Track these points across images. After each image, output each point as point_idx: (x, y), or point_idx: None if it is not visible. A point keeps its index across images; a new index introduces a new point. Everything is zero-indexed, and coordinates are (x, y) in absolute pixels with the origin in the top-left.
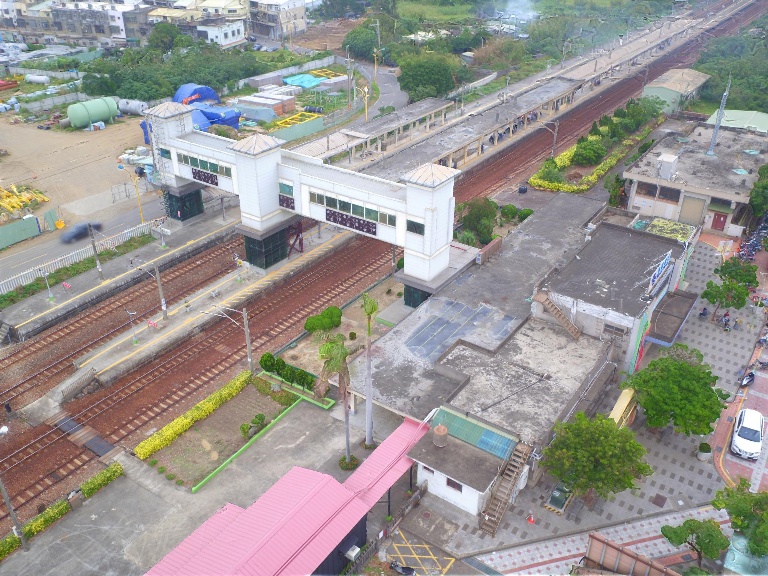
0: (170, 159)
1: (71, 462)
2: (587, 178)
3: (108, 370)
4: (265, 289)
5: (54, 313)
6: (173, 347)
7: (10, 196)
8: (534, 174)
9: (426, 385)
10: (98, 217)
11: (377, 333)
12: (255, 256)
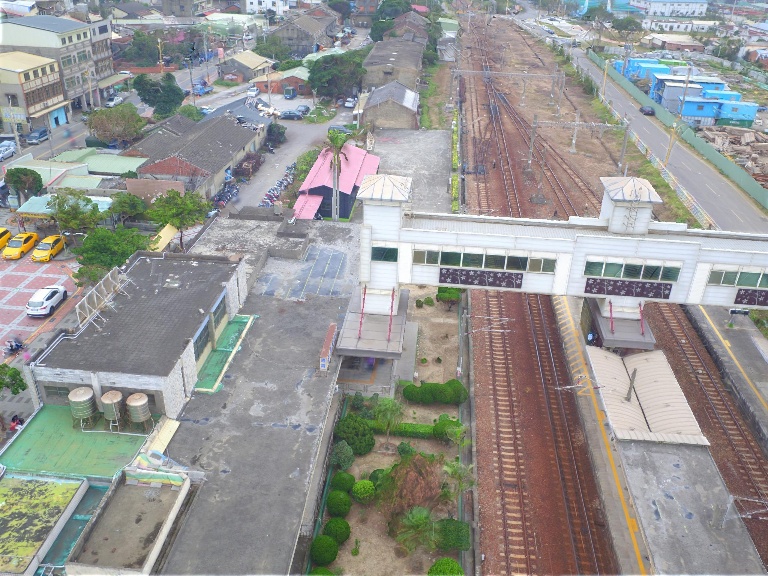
0: None
1: None
2: None
3: None
4: None
5: None
6: None
7: None
8: None
9: None
10: None
11: None
12: None
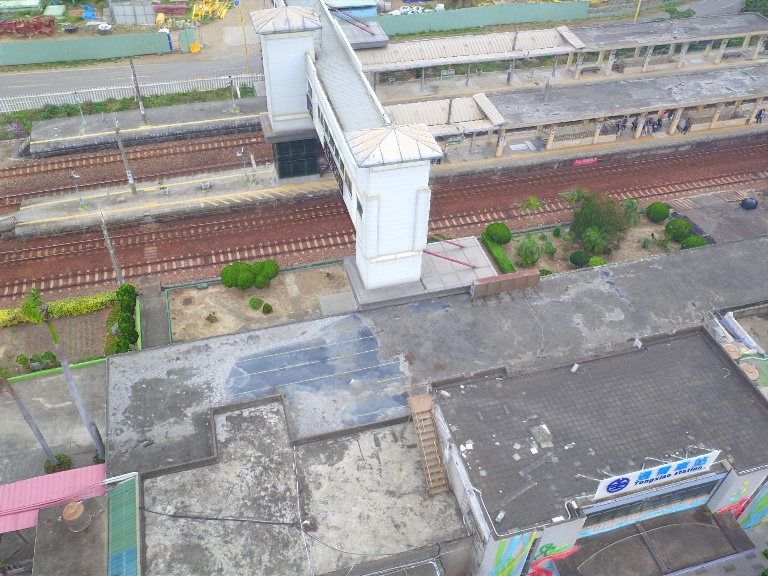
0: None
1: None
2: None
3: (29, 224)
4: (262, 202)
5: (70, 142)
6: (114, 227)
7: (207, 3)
8: None
9: (180, 432)
10: (236, 51)
11: (299, 319)
12: None
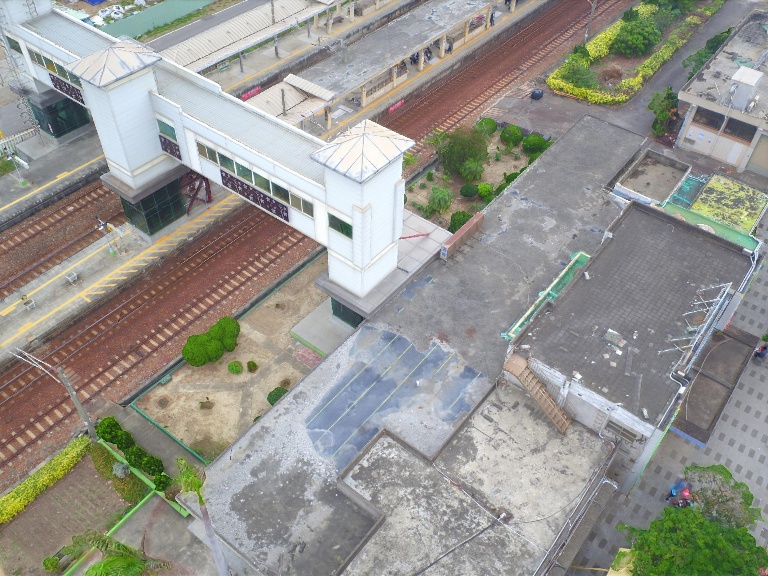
0: (22, 54)
1: None
2: (628, 82)
3: None
4: (148, 268)
5: None
6: None
7: None
8: (556, 70)
9: (320, 518)
10: None
11: (289, 360)
12: (136, 216)
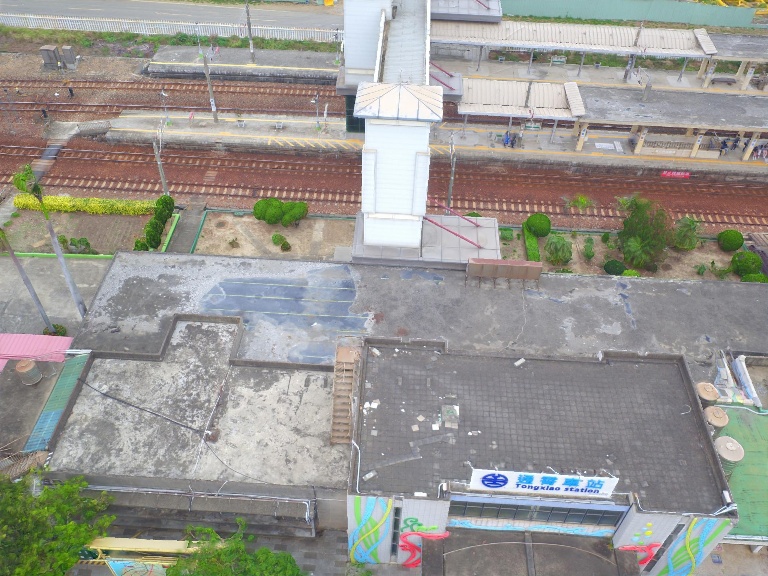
0: None
1: (8, 176)
2: None
3: (119, 131)
4: (325, 151)
5: (183, 67)
6: (189, 148)
7: None
8: None
9: (146, 328)
10: None
11: None
12: None
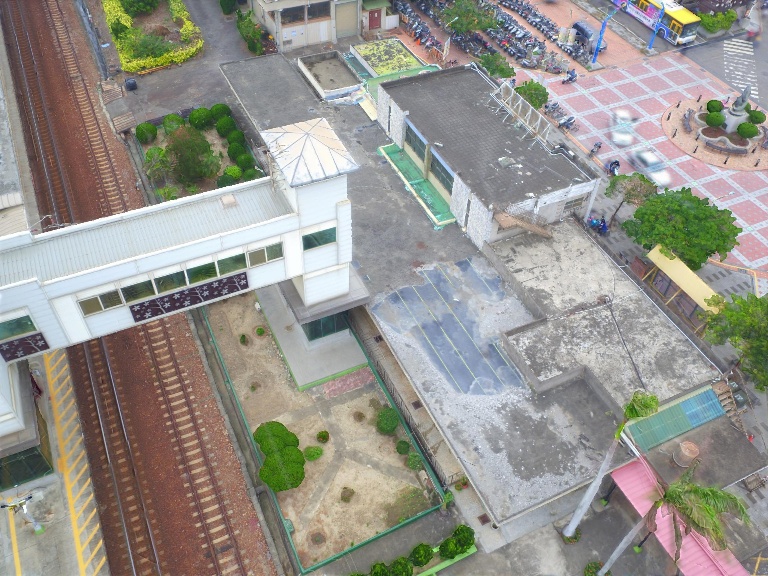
0: None
1: None
2: (187, 29)
3: None
4: (94, 498)
5: None
6: None
7: None
8: (119, 55)
9: (561, 416)
10: None
11: (331, 404)
12: (15, 471)
